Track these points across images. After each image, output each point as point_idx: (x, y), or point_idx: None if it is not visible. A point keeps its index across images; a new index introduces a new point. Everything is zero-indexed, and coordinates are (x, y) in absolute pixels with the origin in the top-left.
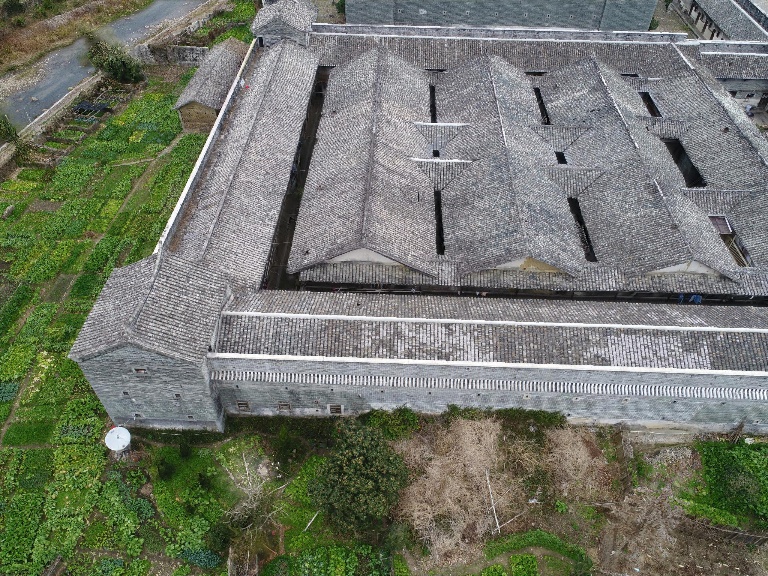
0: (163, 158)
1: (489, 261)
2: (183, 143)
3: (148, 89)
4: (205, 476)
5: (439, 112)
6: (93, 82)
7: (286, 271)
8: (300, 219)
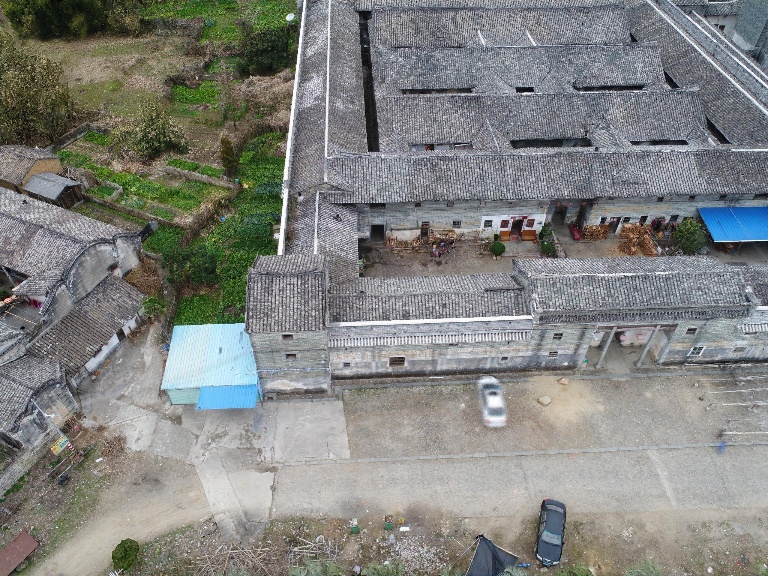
0: None
1: None
2: None
3: None
4: None
5: None
6: None
7: None
8: None
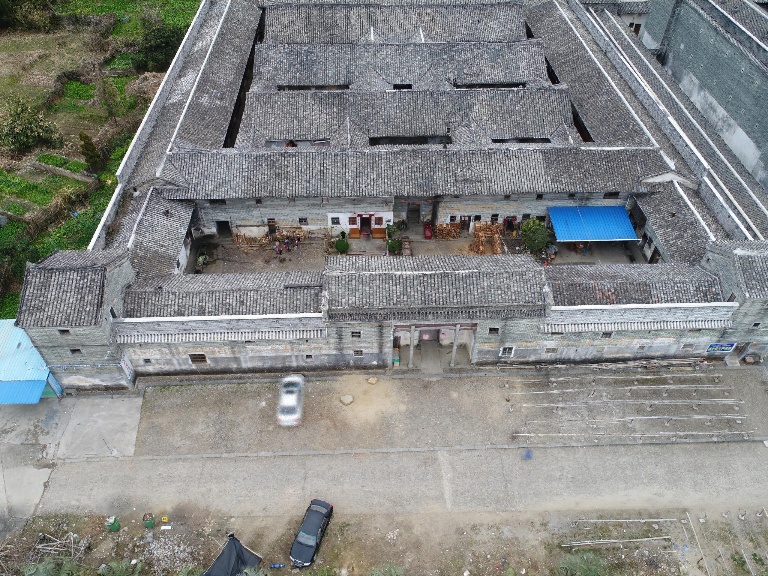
0: None
1: None
2: None
3: None
4: None
5: None
6: None
7: None
8: None
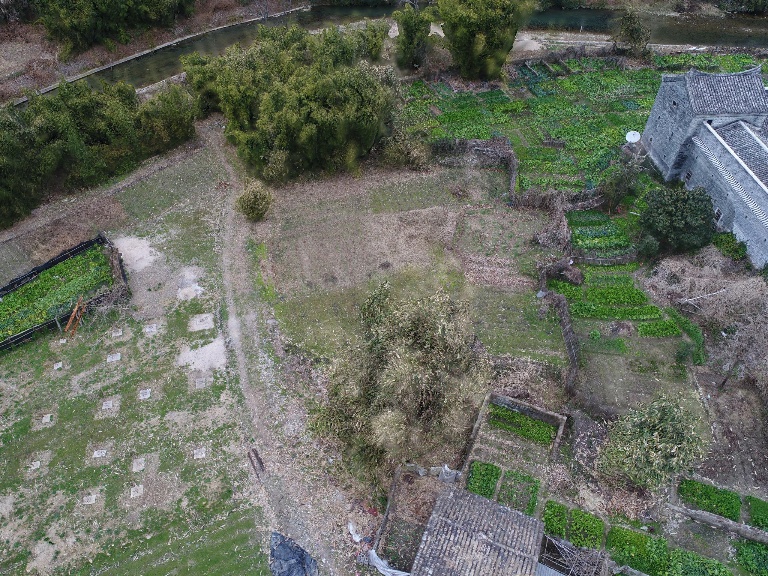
0: None
1: None
2: None
3: None
4: None
5: None
6: None
7: None
8: None
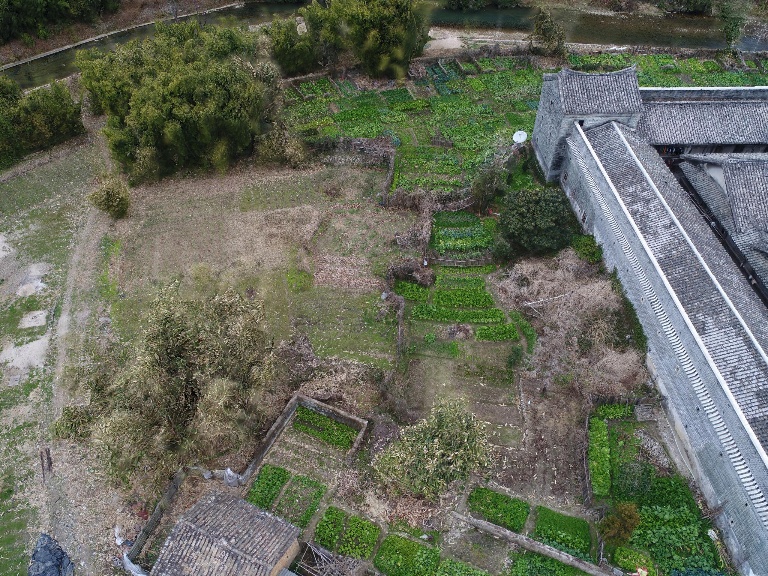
0: None
1: None
2: None
3: None
4: None
5: None
6: None
7: (680, 154)
8: (746, 153)
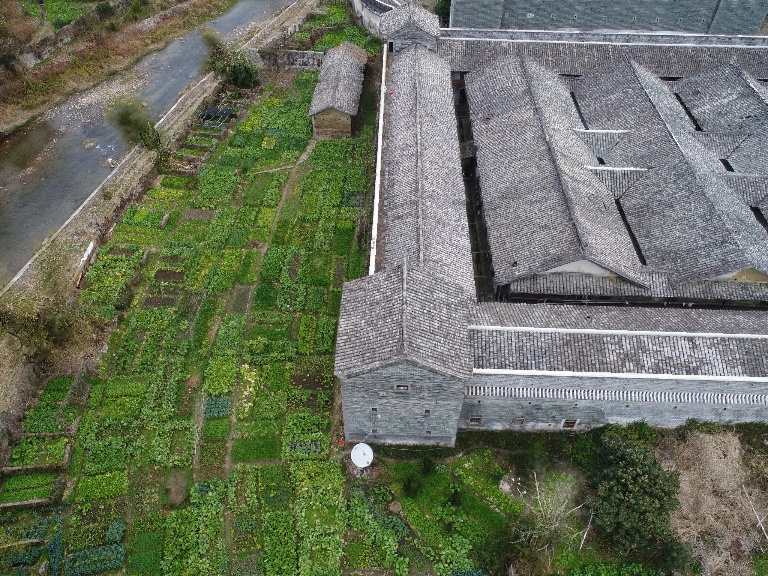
0: (303, 165)
1: (705, 272)
2: (319, 150)
3: (264, 94)
4: (449, 493)
5: (588, 118)
6: (205, 87)
7: (497, 283)
8: (491, 229)
